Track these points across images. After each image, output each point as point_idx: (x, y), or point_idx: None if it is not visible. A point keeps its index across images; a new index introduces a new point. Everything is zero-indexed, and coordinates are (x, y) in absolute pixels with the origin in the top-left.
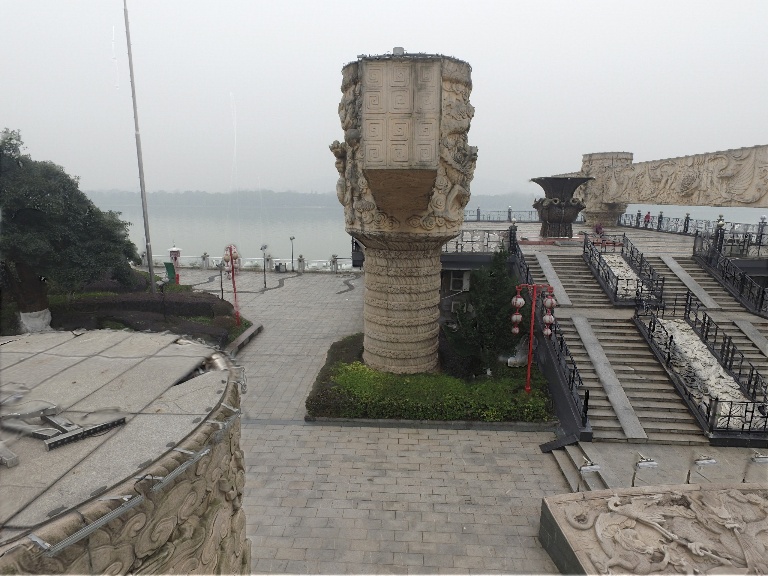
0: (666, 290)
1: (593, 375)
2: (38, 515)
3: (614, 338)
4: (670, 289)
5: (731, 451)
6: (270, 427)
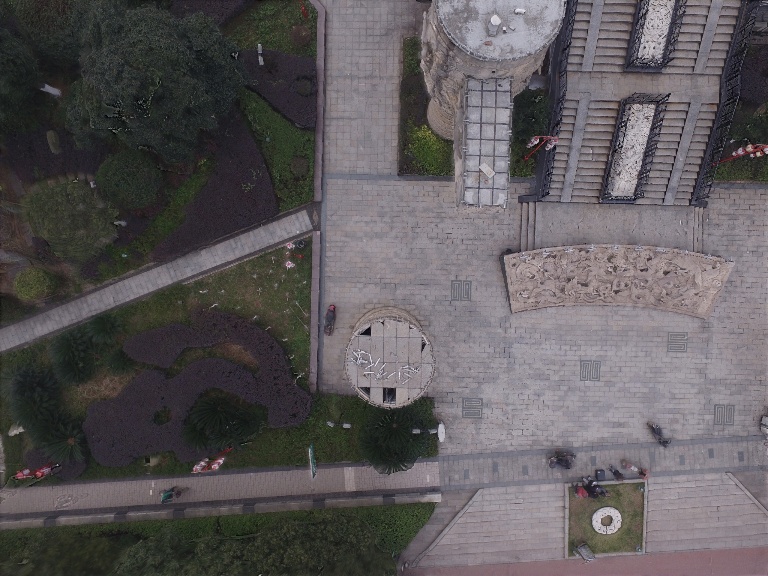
0: (682, 42)
1: (566, 158)
2: (423, 387)
3: (597, 123)
4: (686, 41)
5: (605, 207)
6: (381, 183)
